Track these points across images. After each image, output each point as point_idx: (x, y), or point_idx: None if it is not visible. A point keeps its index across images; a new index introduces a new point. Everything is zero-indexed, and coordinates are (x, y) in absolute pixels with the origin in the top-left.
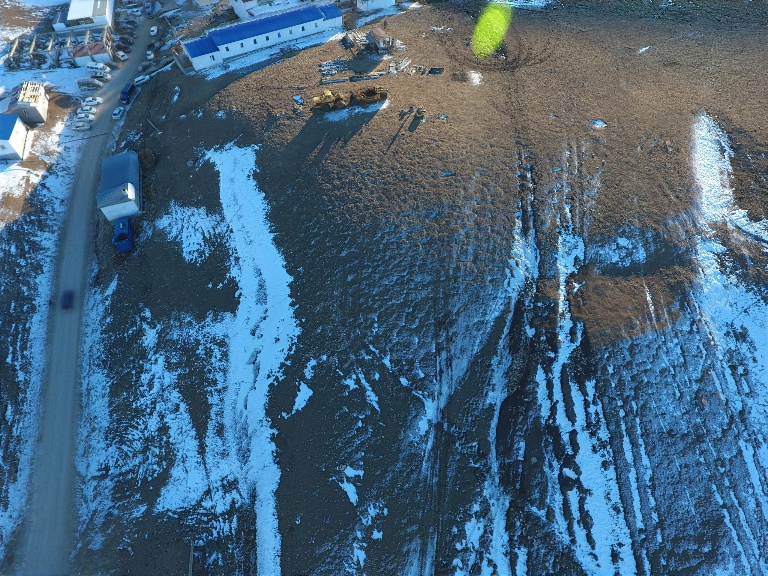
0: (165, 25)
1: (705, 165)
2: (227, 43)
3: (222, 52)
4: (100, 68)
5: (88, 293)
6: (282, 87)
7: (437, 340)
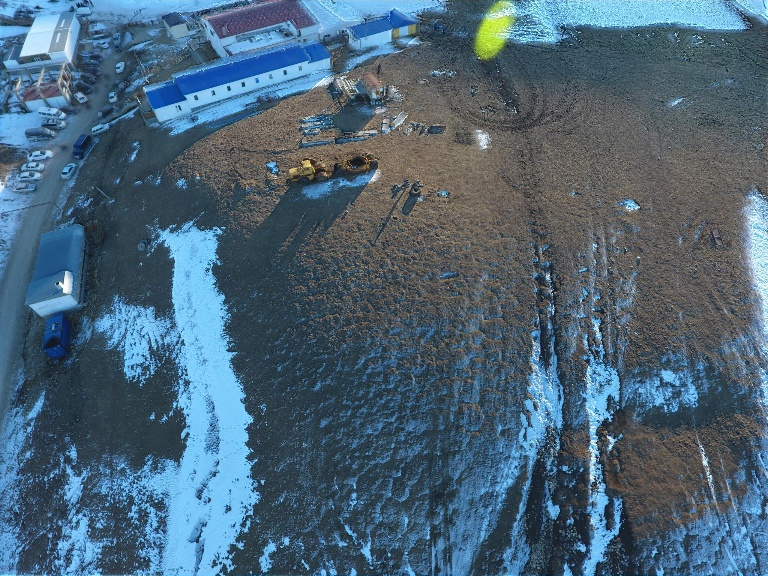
0: (133, 60)
1: (763, 265)
2: (195, 91)
3: (190, 101)
4: (53, 114)
5: (8, 415)
6: (255, 150)
7: (433, 521)
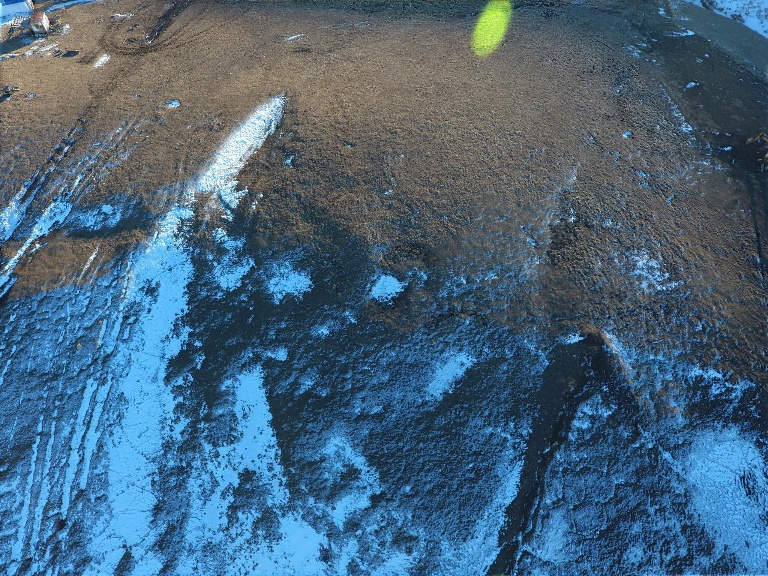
0: None
1: (238, 142)
2: None
3: None
4: None
5: None
6: None
7: None
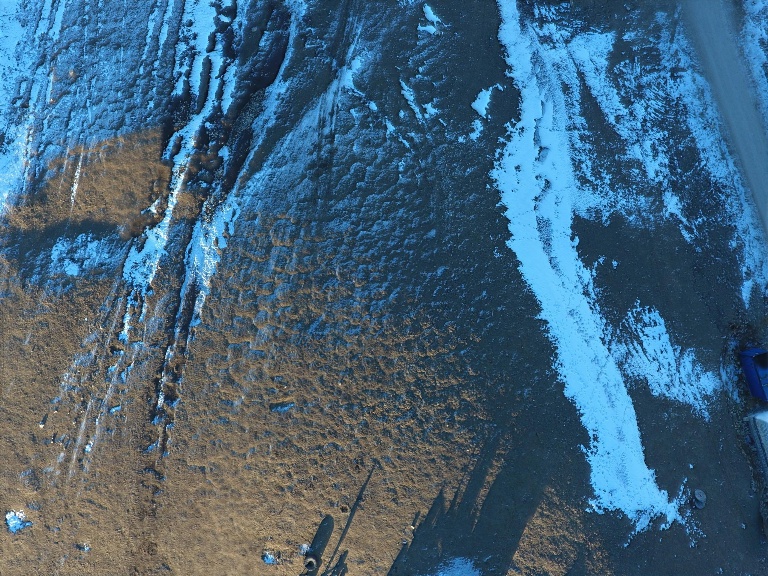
0: None
1: None
2: None
3: None
4: None
5: None
6: None
7: (331, 147)
